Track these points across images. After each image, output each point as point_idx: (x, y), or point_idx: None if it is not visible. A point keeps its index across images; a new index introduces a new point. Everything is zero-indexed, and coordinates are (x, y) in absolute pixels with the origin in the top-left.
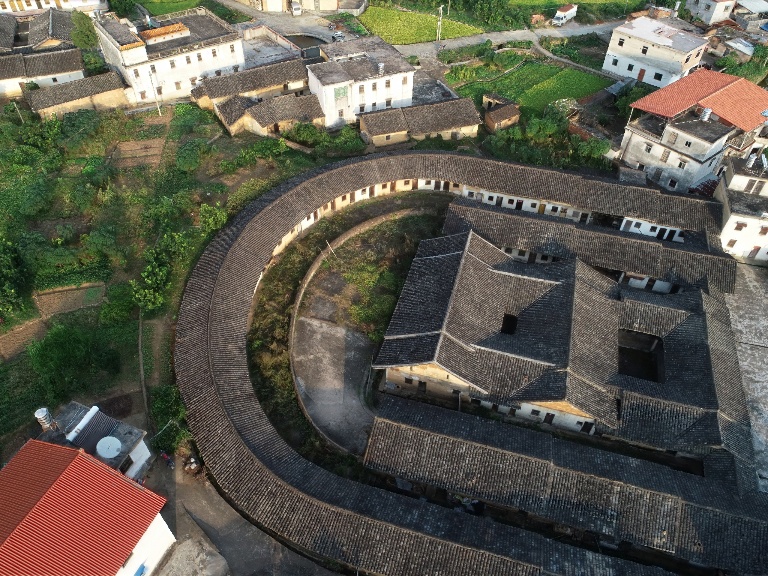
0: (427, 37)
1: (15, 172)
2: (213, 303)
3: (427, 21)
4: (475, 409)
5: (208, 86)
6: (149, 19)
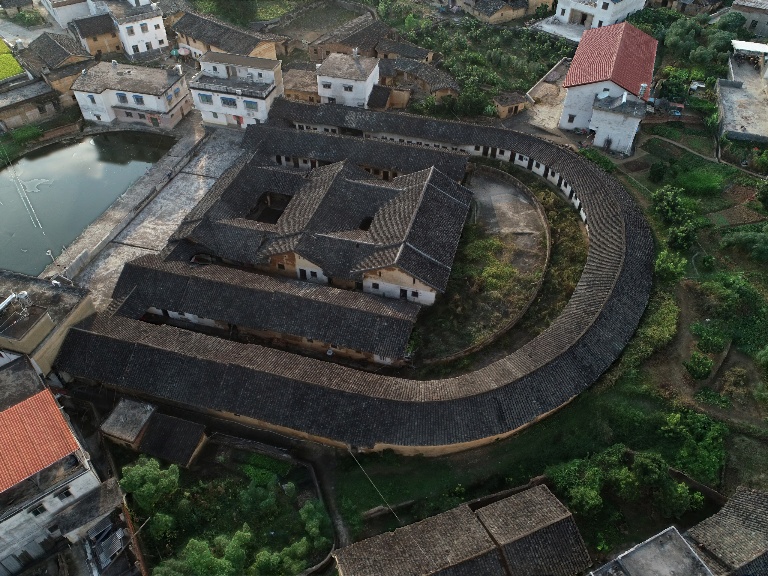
0: None
1: None
2: None
3: None
4: None
5: None
6: None
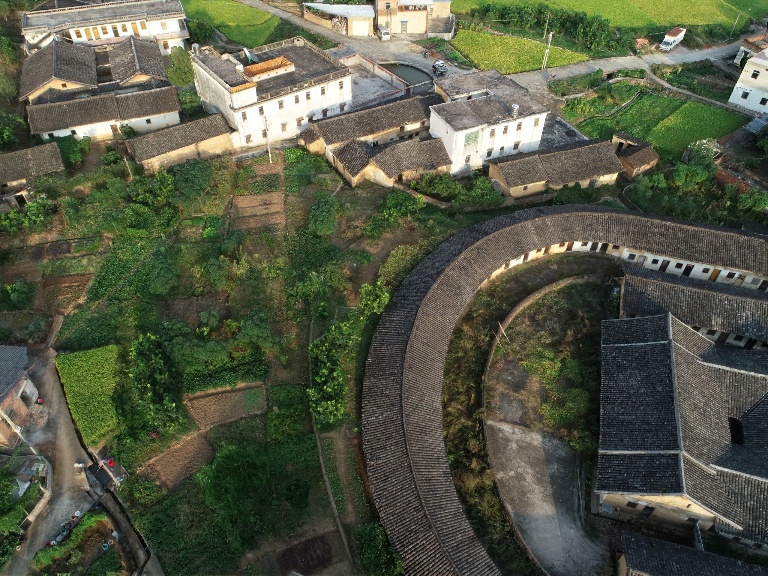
0: (531, 65)
1: (129, 237)
2: (405, 415)
3: (526, 46)
4: (711, 538)
5: (323, 130)
6: (248, 52)
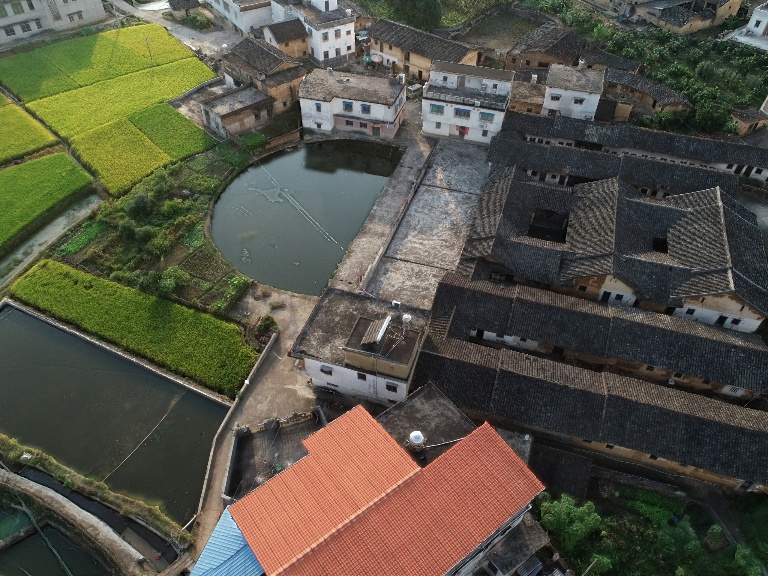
0: None
1: None
2: None
3: None
4: None
5: None
6: None
